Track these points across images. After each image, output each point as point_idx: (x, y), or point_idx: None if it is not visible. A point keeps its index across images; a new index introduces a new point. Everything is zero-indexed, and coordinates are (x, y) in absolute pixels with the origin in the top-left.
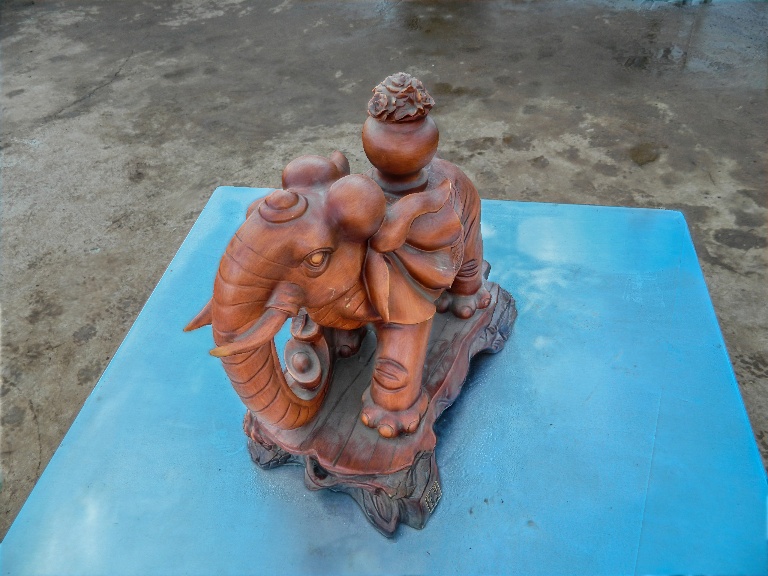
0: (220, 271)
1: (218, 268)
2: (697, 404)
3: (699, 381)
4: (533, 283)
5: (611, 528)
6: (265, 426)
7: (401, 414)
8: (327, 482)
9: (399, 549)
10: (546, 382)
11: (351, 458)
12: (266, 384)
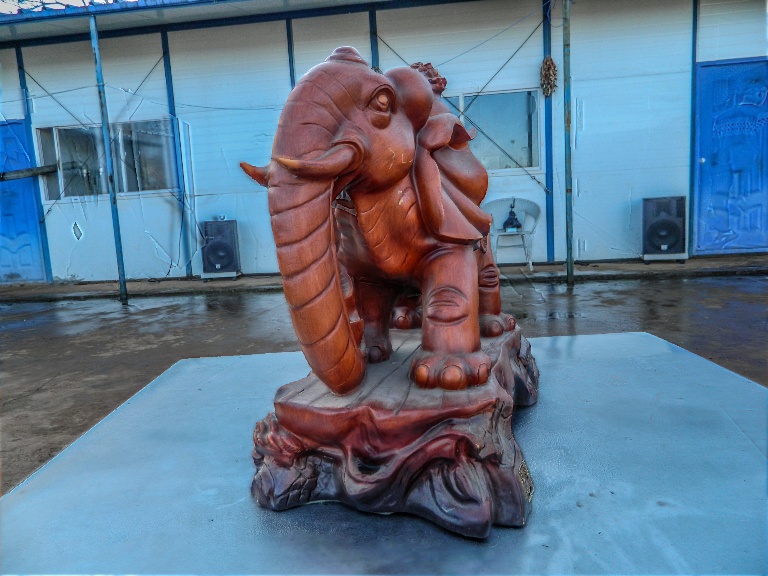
0: (289, 99)
1: (188, 395)
2: (764, 410)
3: (752, 399)
4: (540, 369)
5: (759, 494)
6: (294, 401)
7: (466, 356)
8: (381, 473)
9: (502, 549)
10: (598, 414)
11: (416, 406)
12: (322, 255)
